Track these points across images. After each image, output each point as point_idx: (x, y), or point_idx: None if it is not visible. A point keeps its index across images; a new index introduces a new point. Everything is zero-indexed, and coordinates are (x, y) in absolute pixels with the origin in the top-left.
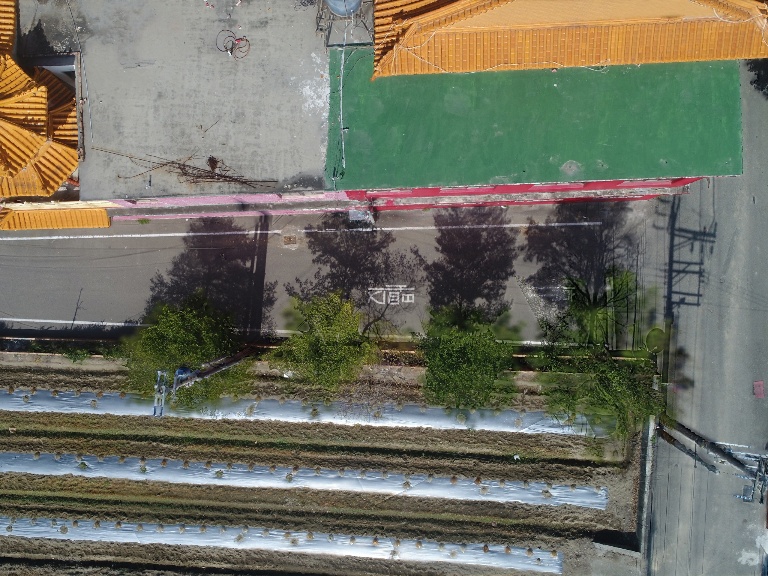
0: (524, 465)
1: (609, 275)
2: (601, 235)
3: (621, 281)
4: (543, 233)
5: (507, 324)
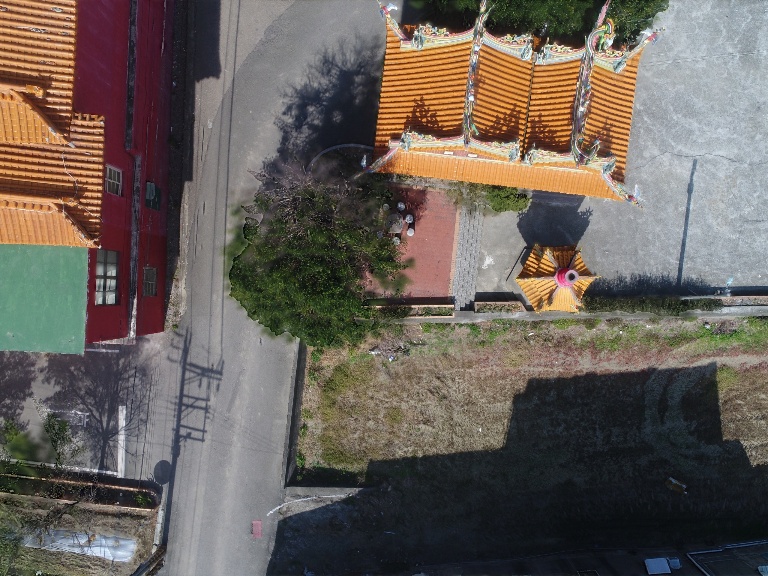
0: None
1: (122, 404)
2: (118, 363)
3: (133, 410)
4: (63, 357)
5: (23, 444)
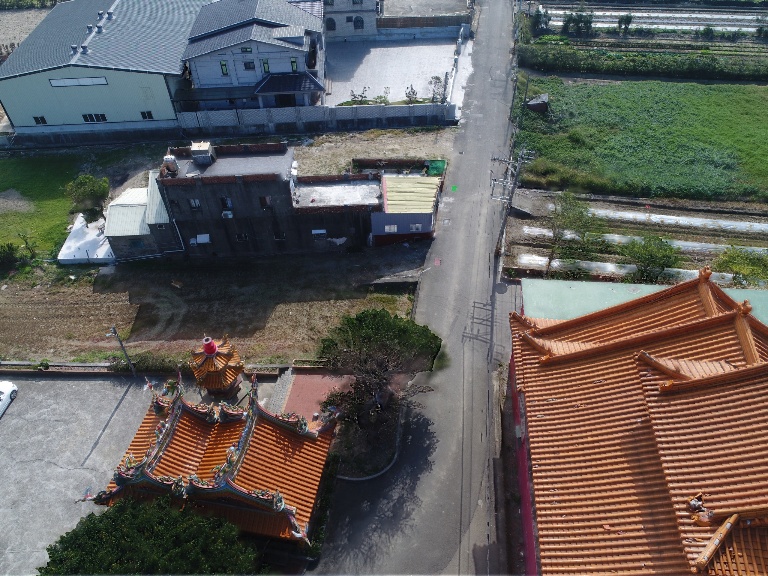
0: (576, 246)
1: None
2: None
3: None
4: None
5: None
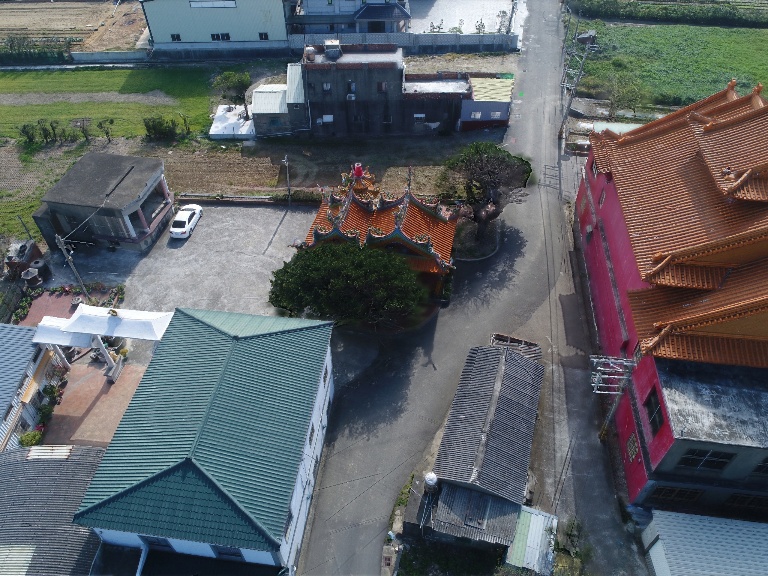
0: None
1: None
2: None
3: None
4: None
5: None
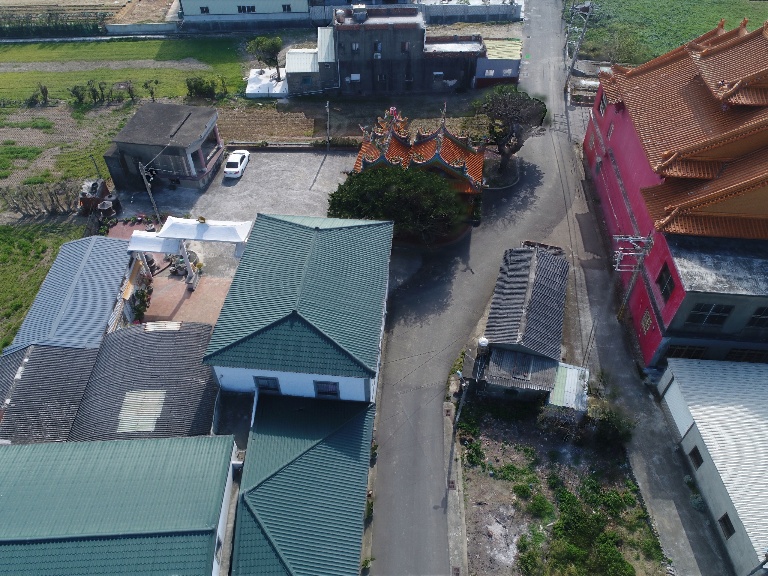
0: None
1: None
2: None
3: None
4: None
5: None
